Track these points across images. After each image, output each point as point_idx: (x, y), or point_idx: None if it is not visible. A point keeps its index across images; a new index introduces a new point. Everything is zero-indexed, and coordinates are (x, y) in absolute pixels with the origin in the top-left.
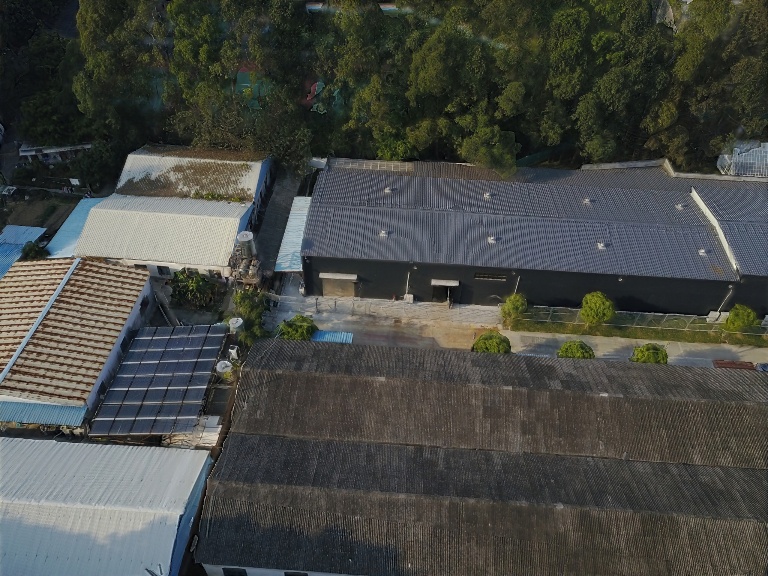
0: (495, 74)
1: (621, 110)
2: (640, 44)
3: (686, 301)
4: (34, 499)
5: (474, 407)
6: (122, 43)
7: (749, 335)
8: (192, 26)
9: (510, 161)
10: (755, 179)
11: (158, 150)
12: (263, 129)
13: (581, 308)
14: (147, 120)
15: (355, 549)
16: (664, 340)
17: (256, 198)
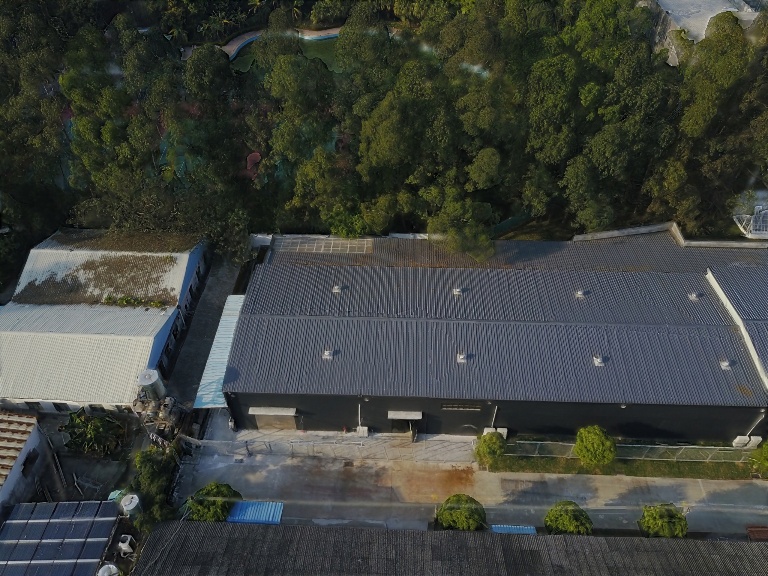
0: (463, 140)
1: (618, 174)
2: (638, 96)
3: (707, 426)
4: None
5: None
6: (10, 122)
7: None
8: (90, 101)
9: (485, 243)
10: None
11: (69, 239)
12: (195, 207)
13: (575, 444)
14: (57, 203)
15: None
16: (681, 477)
17: (182, 298)
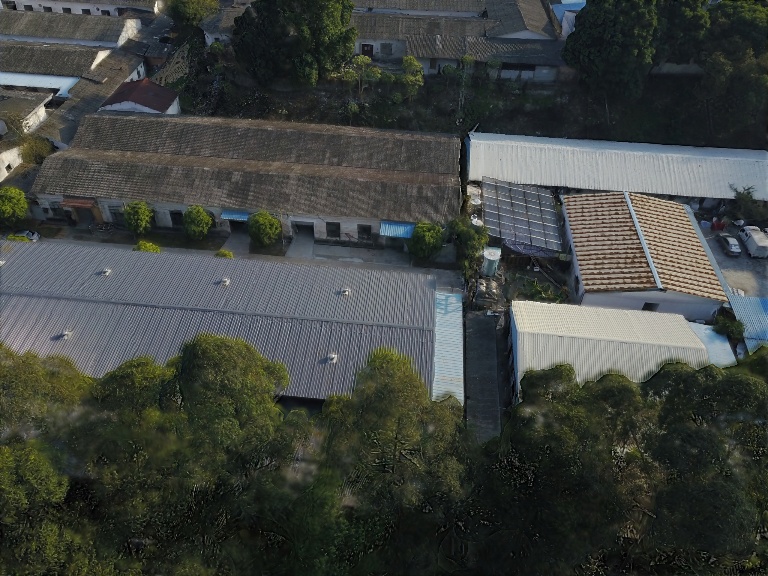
0: None
1: None
2: None
3: None
4: (552, 149)
5: None
6: None
7: None
8: None
9: None
10: None
11: None
12: None
13: None
14: None
15: None
16: None
17: None
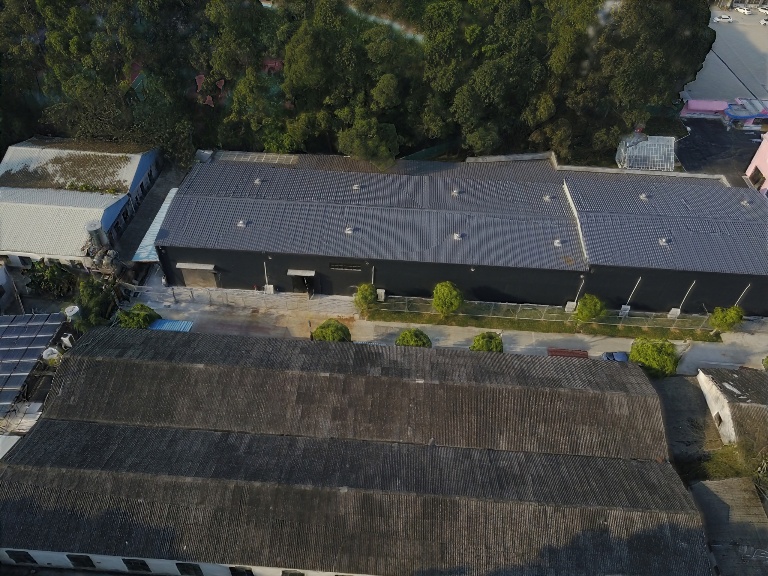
0: (368, 66)
1: (497, 102)
2: (513, 36)
3: (542, 291)
4: None
5: (288, 393)
6: None
7: (605, 325)
8: (61, 18)
9: (385, 153)
10: (638, 172)
11: (42, 142)
12: (150, 122)
13: (434, 298)
14: (33, 113)
15: (133, 532)
16: (519, 330)
17: (133, 190)
